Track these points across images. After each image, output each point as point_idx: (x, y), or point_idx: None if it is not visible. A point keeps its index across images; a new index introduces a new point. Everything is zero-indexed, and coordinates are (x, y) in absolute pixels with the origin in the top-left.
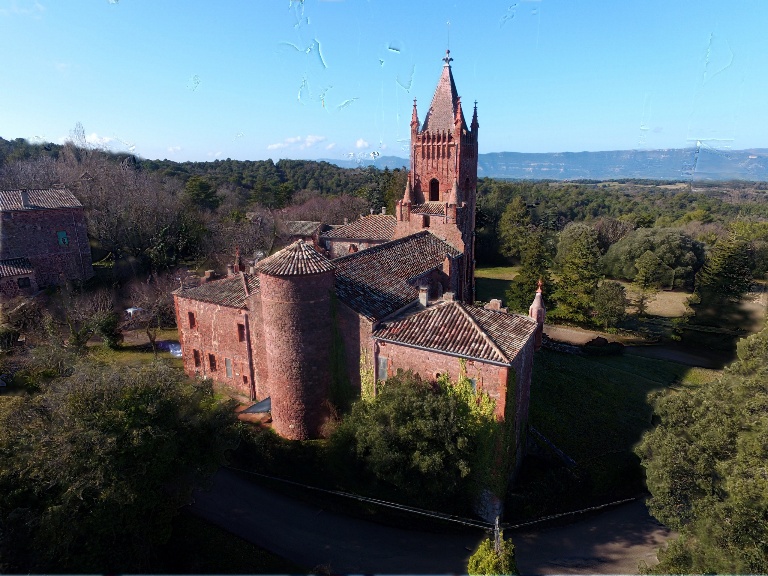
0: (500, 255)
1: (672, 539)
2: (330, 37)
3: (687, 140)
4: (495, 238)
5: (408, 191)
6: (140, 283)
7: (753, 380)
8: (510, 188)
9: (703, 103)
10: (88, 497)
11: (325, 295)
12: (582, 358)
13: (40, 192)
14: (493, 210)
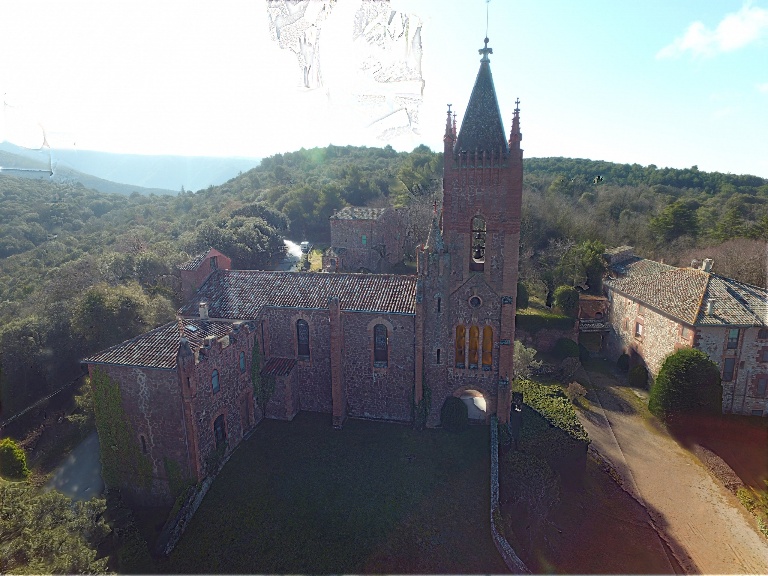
0: None
1: None
2: (431, 62)
3: None
4: None
5: None
6: None
7: None
8: None
9: None
10: (94, 333)
11: (189, 287)
12: None
13: (373, 209)
14: None
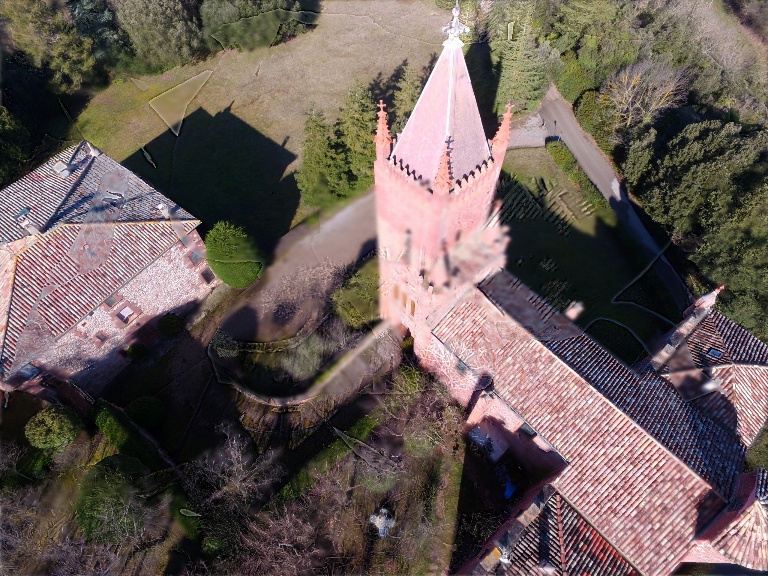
0: (58, 95)
1: None
2: None
3: None
4: (27, 73)
5: None
6: None
7: None
8: None
9: None
10: None
11: None
12: None
13: None
14: None
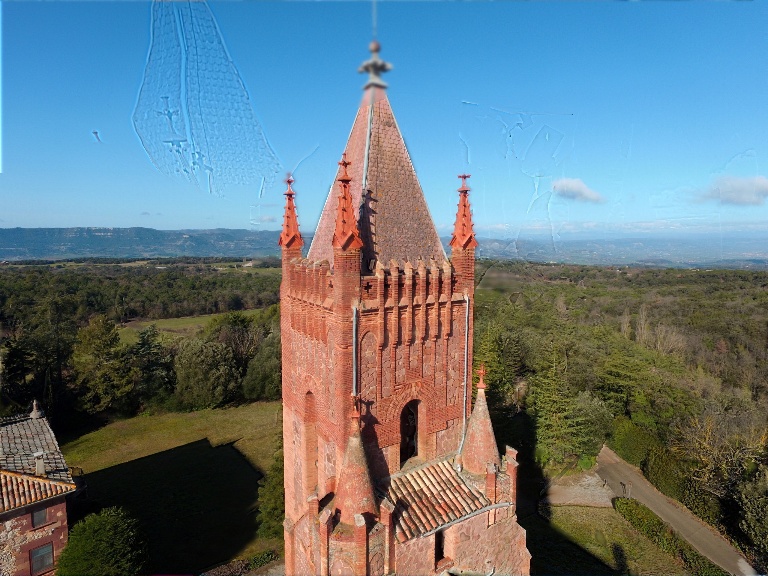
0: (79, 413)
1: None
2: None
3: None
4: (63, 388)
5: (364, 469)
6: None
7: None
8: (73, 302)
9: (298, 201)
10: None
11: None
12: None
13: None
14: (48, 342)
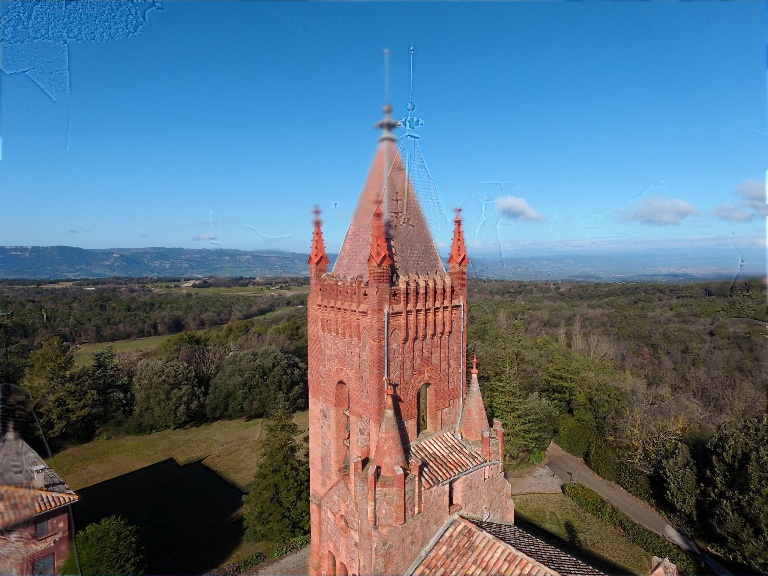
0: None
1: None
2: None
3: (255, 256)
4: None
5: (398, 433)
6: None
7: None
8: (23, 325)
9: None
10: None
11: None
12: None
13: None
14: None
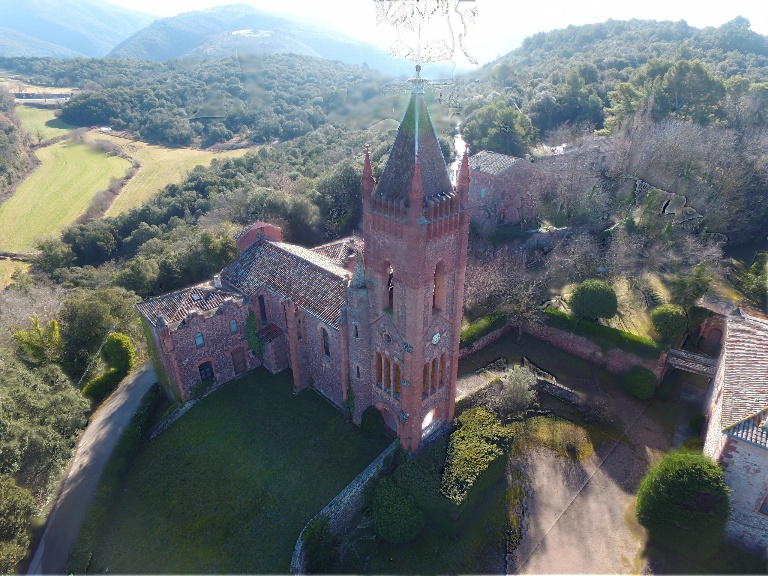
0: None
1: (76, 462)
2: None
3: None
4: None
5: None
6: (497, 244)
7: (4, 353)
8: None
9: None
10: None
11: None
12: (279, 575)
13: (504, 159)
14: None
